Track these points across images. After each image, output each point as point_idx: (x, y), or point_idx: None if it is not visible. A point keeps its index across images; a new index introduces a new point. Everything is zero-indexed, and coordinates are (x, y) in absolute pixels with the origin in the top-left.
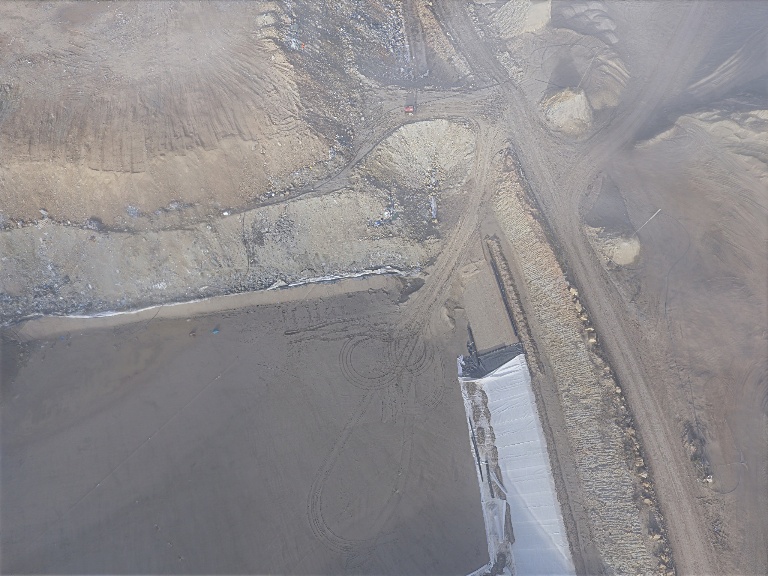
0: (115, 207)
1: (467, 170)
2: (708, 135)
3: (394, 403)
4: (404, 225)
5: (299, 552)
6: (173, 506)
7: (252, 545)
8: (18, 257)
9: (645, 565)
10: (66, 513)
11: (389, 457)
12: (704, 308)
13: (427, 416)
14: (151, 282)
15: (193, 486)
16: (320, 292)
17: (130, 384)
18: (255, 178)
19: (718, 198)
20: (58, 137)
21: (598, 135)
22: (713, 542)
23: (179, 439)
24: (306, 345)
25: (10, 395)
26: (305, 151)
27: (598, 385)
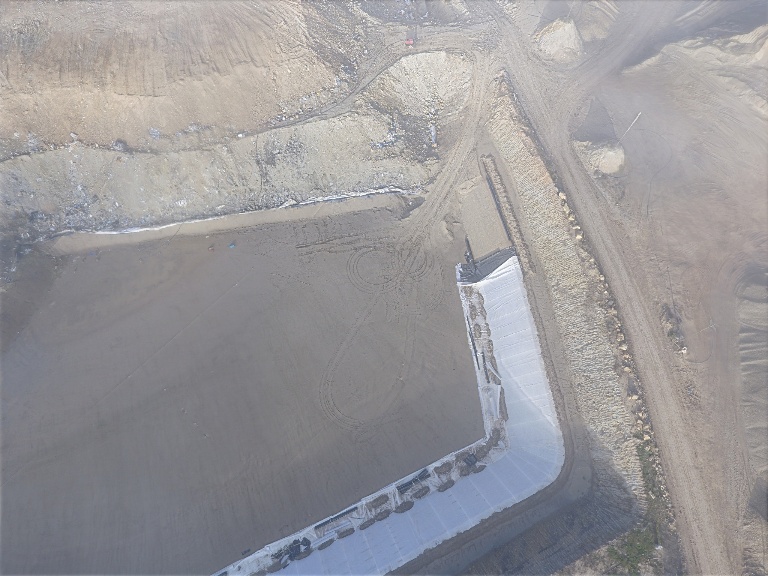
0: (139, 130)
1: (464, 97)
2: (692, 61)
3: (397, 305)
4: (405, 147)
5: (312, 430)
6: (198, 393)
7: (270, 424)
8: (51, 178)
9: (624, 422)
10: (101, 400)
11: (393, 350)
12: (683, 209)
13: (428, 315)
14: (173, 199)
15: (215, 376)
16: (328, 210)
17: (155, 292)
18: (267, 103)
19: (699, 116)
20: (86, 65)
21: (587, 63)
22: (686, 403)
23: (201, 337)
24: (316, 257)
25: (47, 302)
26: (313, 78)
27: (584, 275)
